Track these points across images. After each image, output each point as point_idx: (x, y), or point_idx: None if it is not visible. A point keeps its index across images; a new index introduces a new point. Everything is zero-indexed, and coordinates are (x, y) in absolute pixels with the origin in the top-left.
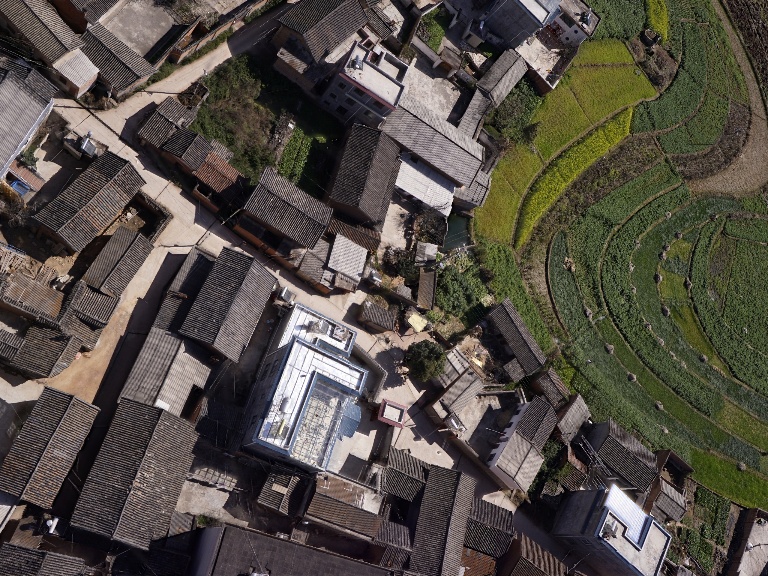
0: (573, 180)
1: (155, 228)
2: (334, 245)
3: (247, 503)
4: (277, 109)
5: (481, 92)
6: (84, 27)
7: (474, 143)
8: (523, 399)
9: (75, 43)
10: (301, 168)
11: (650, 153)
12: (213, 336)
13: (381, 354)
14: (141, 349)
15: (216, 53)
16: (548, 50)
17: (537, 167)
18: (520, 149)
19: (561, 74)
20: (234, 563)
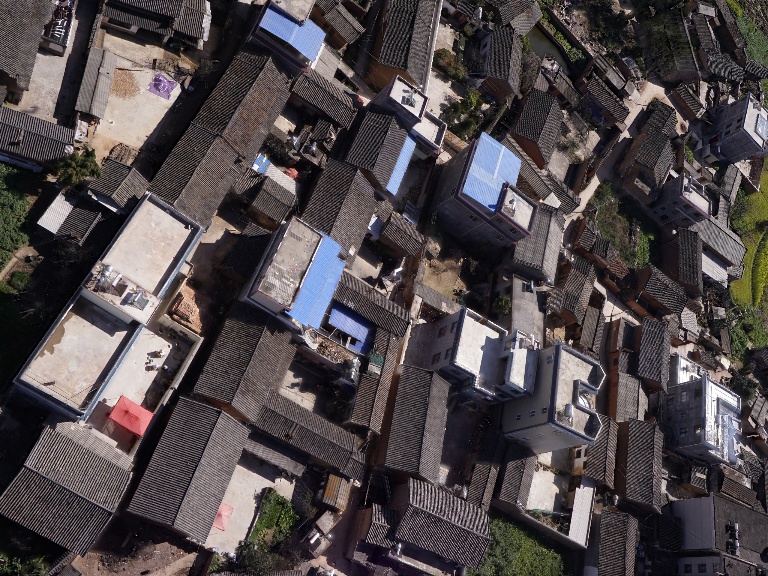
0: None
1: (601, 306)
2: None
3: (676, 487)
4: (629, 218)
5: (723, 197)
6: None
7: (736, 236)
8: None
9: (551, 186)
10: (647, 259)
11: None
12: (658, 377)
13: None
14: (618, 387)
15: (592, 182)
16: (744, 161)
17: (754, 248)
18: (743, 235)
19: (759, 180)
20: (722, 518)
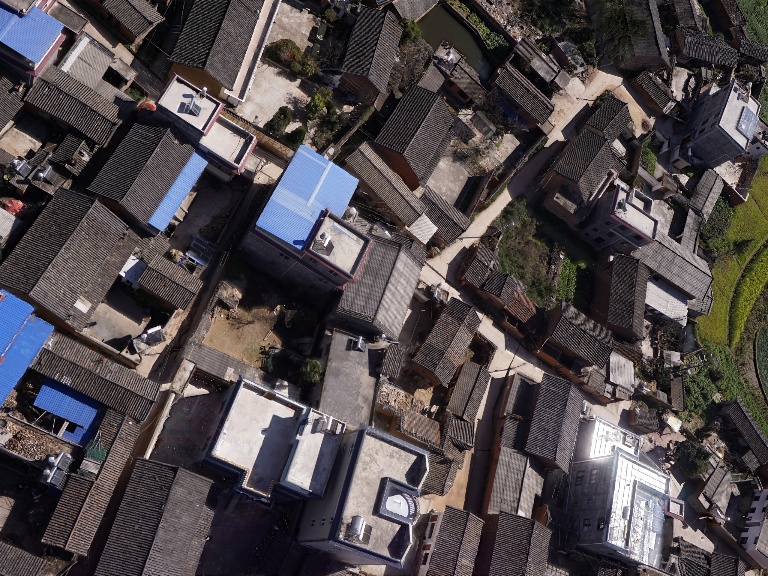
0: None
1: (487, 359)
2: (610, 361)
3: None
4: (550, 243)
5: (693, 211)
6: (413, 189)
7: (701, 260)
8: (761, 486)
9: (422, 208)
10: (572, 293)
11: None
12: (553, 453)
13: (649, 453)
14: (497, 466)
15: (501, 198)
16: (733, 164)
17: (737, 272)
18: (722, 257)
19: (749, 187)
20: None
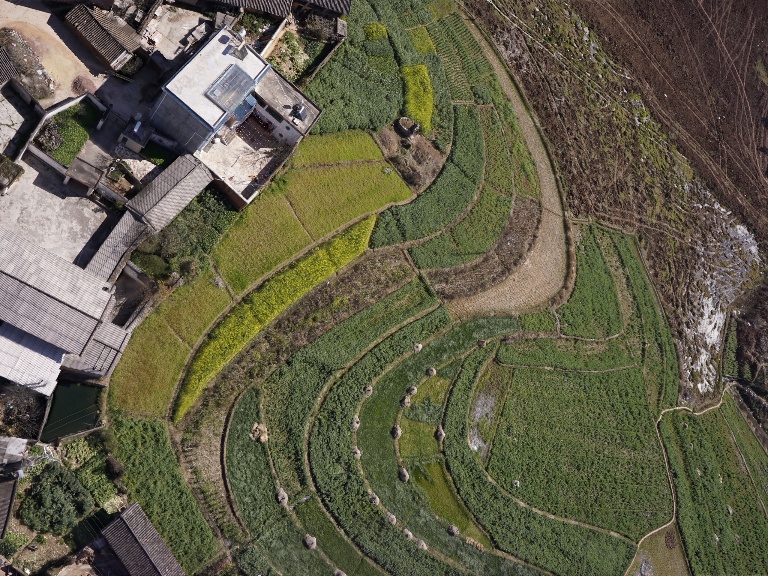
0: (277, 317)
1: None
2: None
3: None
4: None
5: (132, 214)
6: None
7: (96, 292)
8: None
9: None
10: None
11: (397, 271)
12: None
13: None
14: None
15: None
16: (254, 150)
17: (222, 305)
18: (198, 283)
19: (264, 182)
20: None
